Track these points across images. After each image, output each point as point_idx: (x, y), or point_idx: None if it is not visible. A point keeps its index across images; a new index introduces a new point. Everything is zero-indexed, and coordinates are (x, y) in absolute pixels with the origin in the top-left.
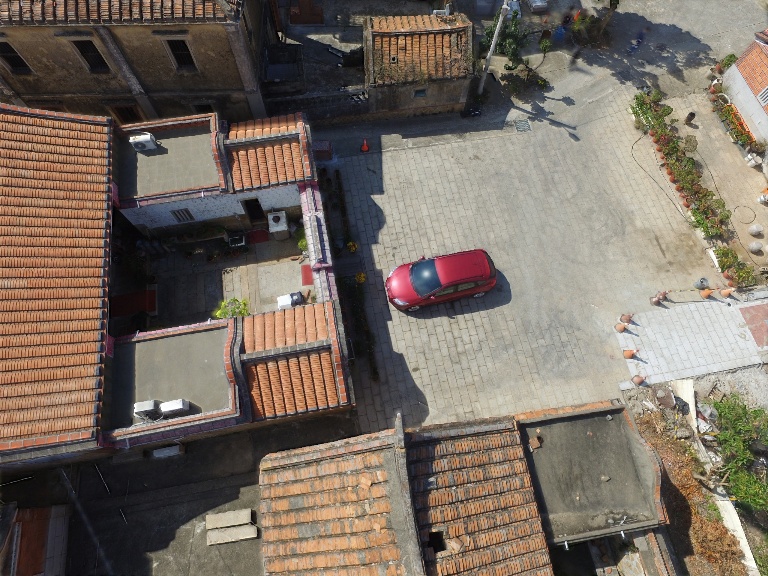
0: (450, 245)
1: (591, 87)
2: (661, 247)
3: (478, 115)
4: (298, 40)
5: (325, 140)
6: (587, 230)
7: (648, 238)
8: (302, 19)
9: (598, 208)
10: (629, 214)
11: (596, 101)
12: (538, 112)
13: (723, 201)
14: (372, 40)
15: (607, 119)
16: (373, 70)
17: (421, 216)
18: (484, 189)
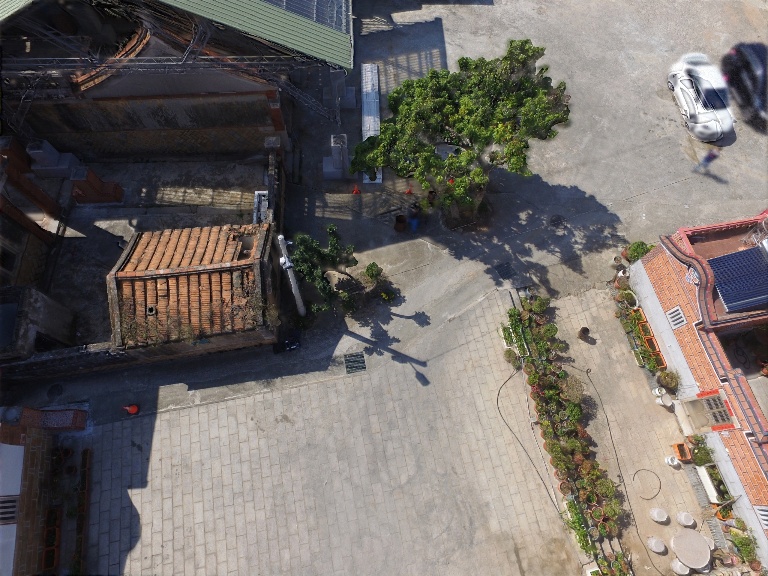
0: (224, 575)
1: (455, 294)
2: (521, 565)
3: (296, 348)
4: (81, 230)
5: (69, 410)
6: (421, 540)
7: (504, 550)
8: (91, 199)
9: (440, 500)
10: (482, 508)
11: (459, 317)
12: (379, 339)
13: (611, 484)
14: (117, 288)
15: (470, 347)
16: (120, 328)
17: (192, 524)
18: (287, 473)
